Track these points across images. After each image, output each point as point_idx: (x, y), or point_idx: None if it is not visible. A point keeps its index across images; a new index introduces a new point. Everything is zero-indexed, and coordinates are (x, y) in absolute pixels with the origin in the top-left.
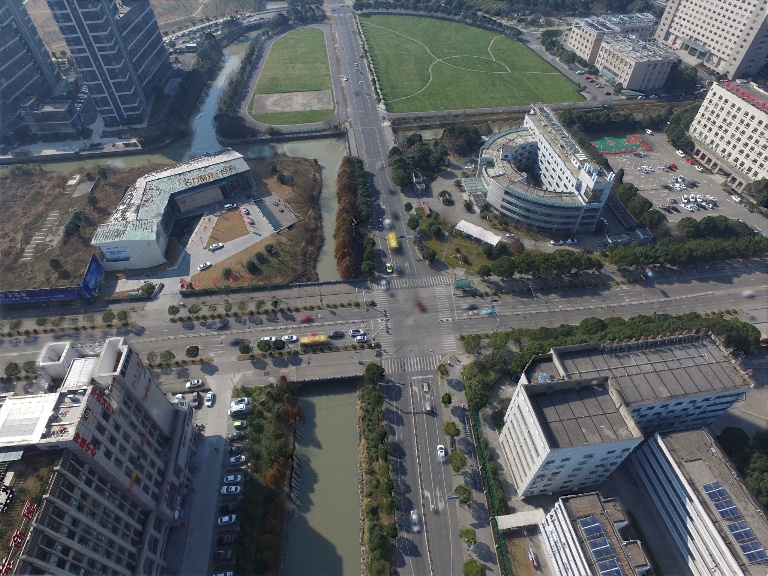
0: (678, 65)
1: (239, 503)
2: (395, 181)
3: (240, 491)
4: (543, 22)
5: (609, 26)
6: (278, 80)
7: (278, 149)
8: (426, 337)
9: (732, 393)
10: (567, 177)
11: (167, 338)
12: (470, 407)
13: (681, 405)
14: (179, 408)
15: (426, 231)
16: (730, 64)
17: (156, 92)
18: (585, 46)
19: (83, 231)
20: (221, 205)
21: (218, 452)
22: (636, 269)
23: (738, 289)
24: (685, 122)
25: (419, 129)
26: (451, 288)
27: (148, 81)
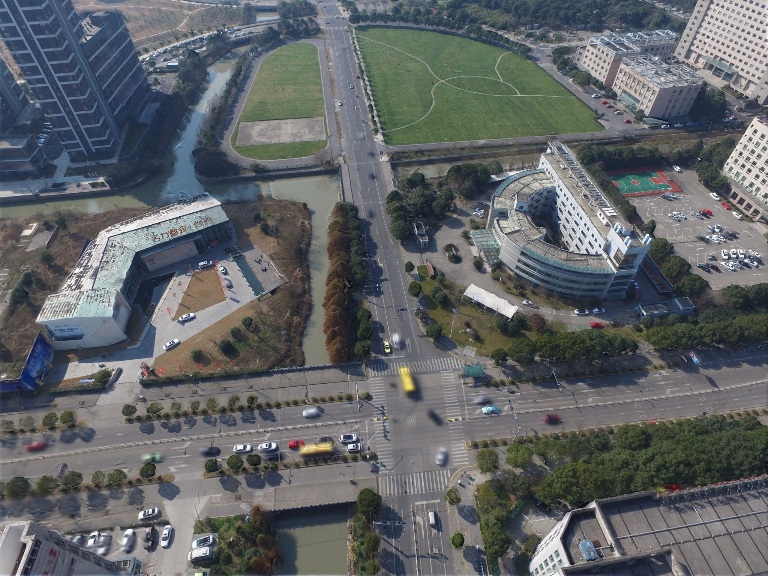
0: None
1: None
2: (394, 234)
3: None
4: (553, 37)
5: (627, 45)
6: (266, 105)
7: (263, 189)
8: (431, 444)
9: None
10: (593, 235)
11: (120, 446)
12: (487, 550)
13: None
14: (120, 573)
15: (430, 297)
16: (761, 88)
17: (130, 121)
18: (601, 67)
19: (34, 297)
20: (195, 262)
21: None
22: (676, 348)
23: None
24: (719, 159)
25: (421, 164)
26: (460, 374)
27: (121, 109)
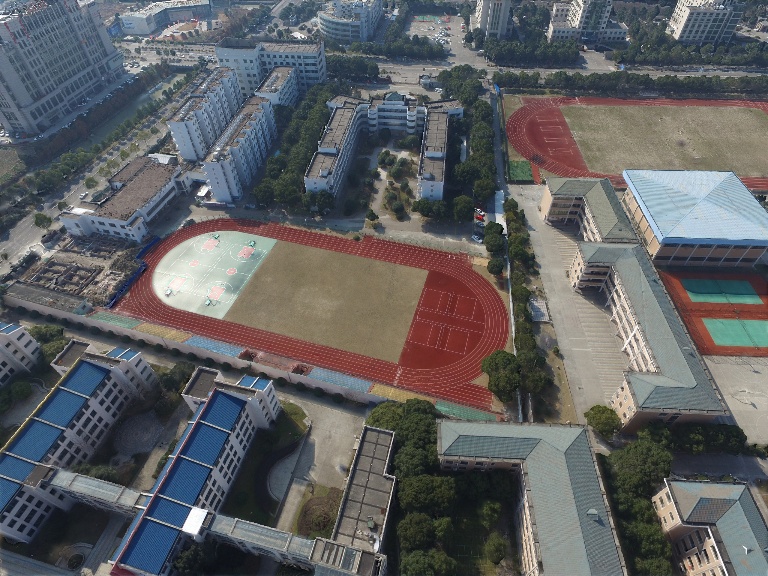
0: None
1: (126, 82)
2: (279, 16)
3: (130, 83)
4: None
5: None
6: None
7: None
8: None
9: (309, 55)
10: None
11: None
12: None
13: (289, 59)
14: (117, 50)
15: None
16: None
17: None
18: None
19: None
20: None
21: (130, 76)
22: (367, 57)
23: (409, 68)
24: None
25: None
26: None
27: None
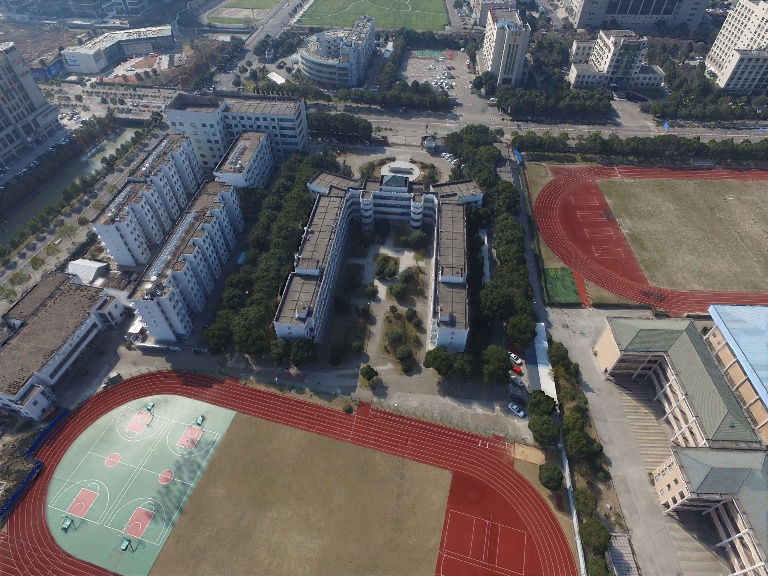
0: (541, 16)
1: None
2: (253, 51)
3: (64, 144)
4: None
5: None
6: (242, 1)
7: (209, 36)
8: None
9: (286, 118)
10: None
11: None
12: None
13: (260, 121)
14: (48, 102)
15: None
16: (577, 16)
17: None
18: None
19: None
20: None
21: (66, 133)
22: (357, 107)
23: (408, 122)
24: (482, 42)
25: None
26: None
27: None
